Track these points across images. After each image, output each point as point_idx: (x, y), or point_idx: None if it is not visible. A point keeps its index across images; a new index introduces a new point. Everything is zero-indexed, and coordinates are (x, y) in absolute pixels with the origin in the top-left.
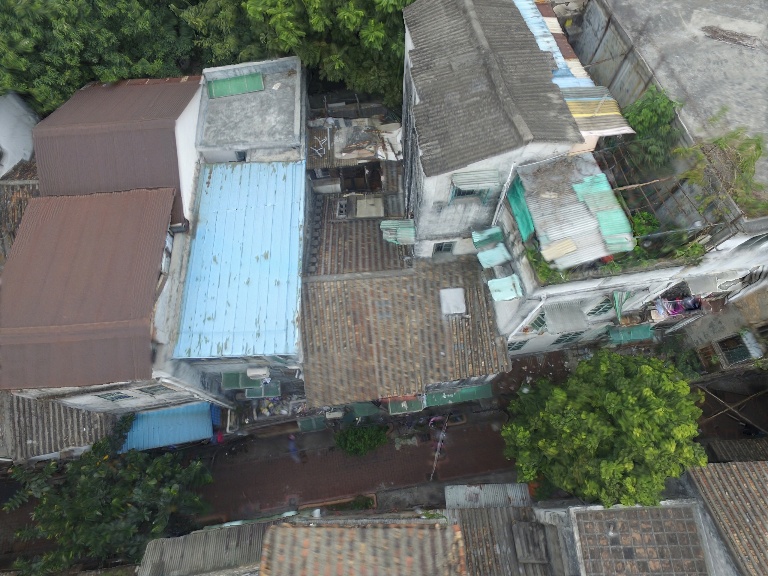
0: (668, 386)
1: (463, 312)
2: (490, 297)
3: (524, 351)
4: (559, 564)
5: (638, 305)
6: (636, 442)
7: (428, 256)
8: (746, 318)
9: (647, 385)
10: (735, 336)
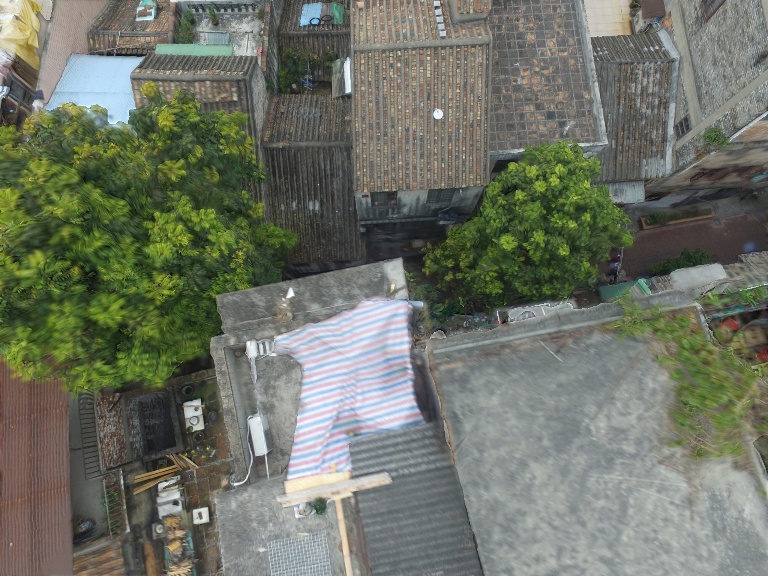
0: (540, 235)
1: None
2: None
3: None
4: None
5: None
6: None
7: None
8: None
9: (560, 236)
10: None
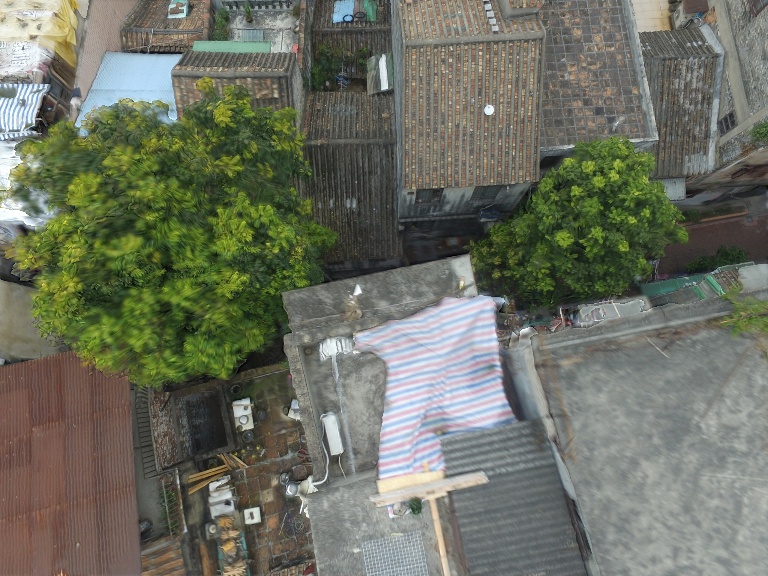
0: (598, 231)
1: None
2: None
3: None
4: None
5: None
6: None
7: None
8: None
9: (619, 233)
10: None
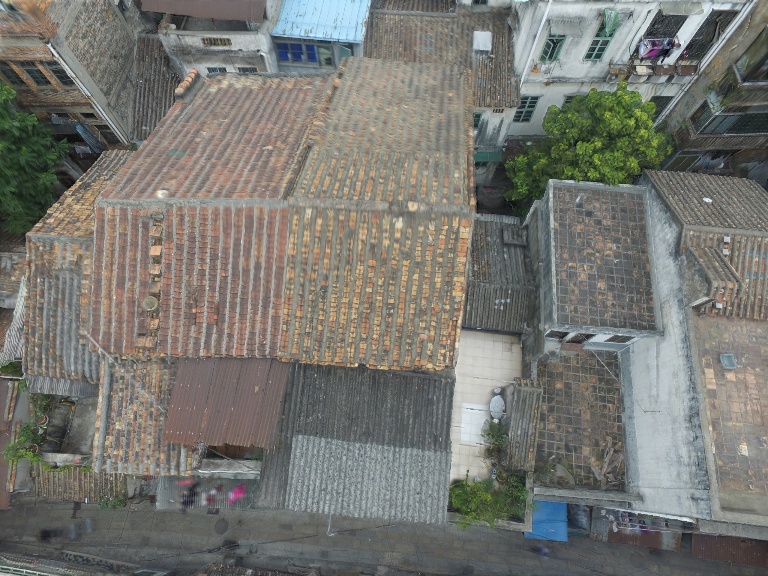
0: (638, 97)
1: (489, 50)
2: (512, 44)
3: (533, 131)
4: (535, 235)
5: (626, 56)
6: (605, 119)
7: (468, 3)
8: (712, 79)
9: None
10: (703, 102)
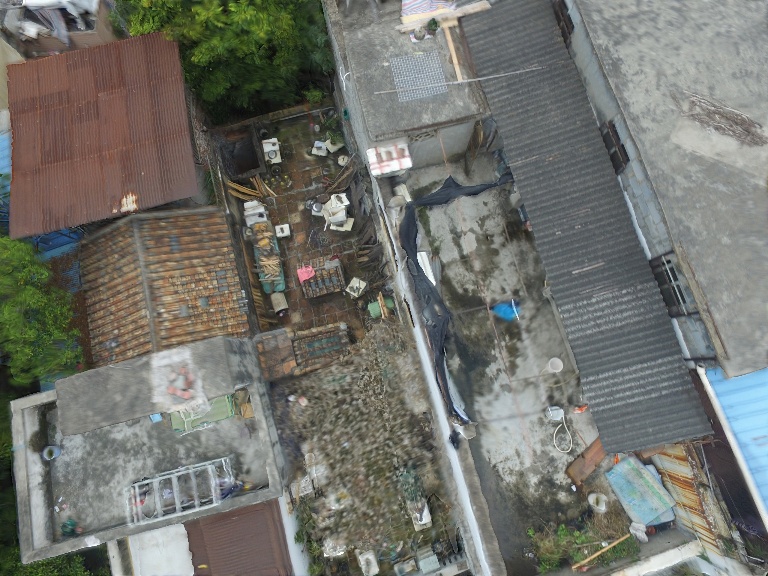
0: None
1: None
2: None
3: None
4: None
5: None
6: None
7: None
8: None
9: None
10: None
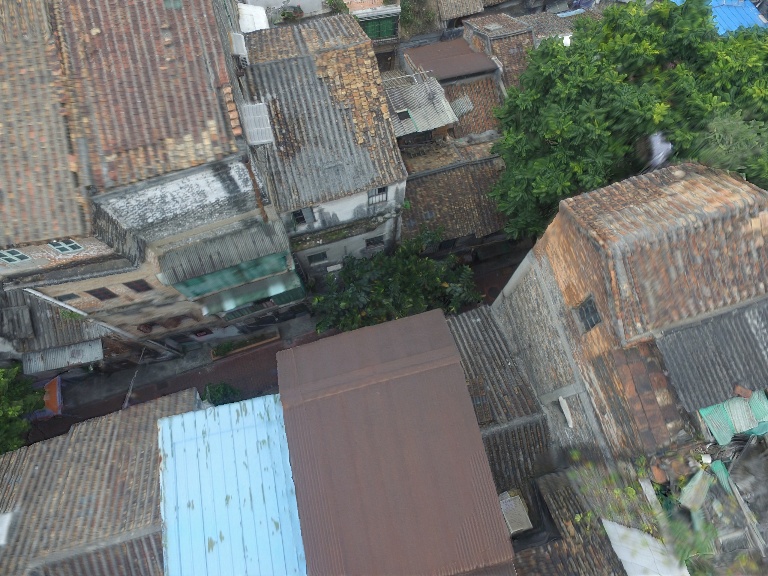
0: None
1: None
2: None
3: None
4: None
5: None
6: None
7: None
8: None
9: None
10: None
